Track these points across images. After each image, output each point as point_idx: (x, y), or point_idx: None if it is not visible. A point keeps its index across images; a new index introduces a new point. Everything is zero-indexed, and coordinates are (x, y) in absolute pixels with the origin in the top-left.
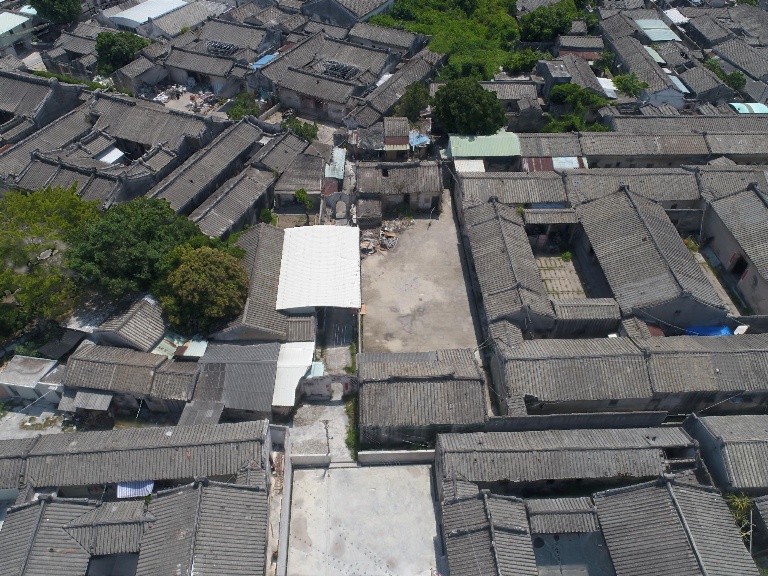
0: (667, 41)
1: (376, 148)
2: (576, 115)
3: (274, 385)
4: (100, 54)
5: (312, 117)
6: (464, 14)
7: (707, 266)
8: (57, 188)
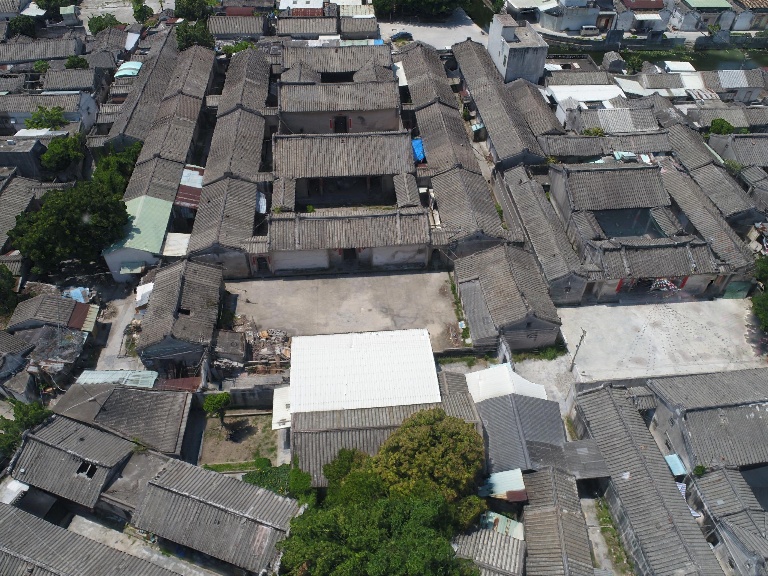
0: None
1: (82, 342)
2: None
3: None
4: None
5: None
6: None
7: None
8: None
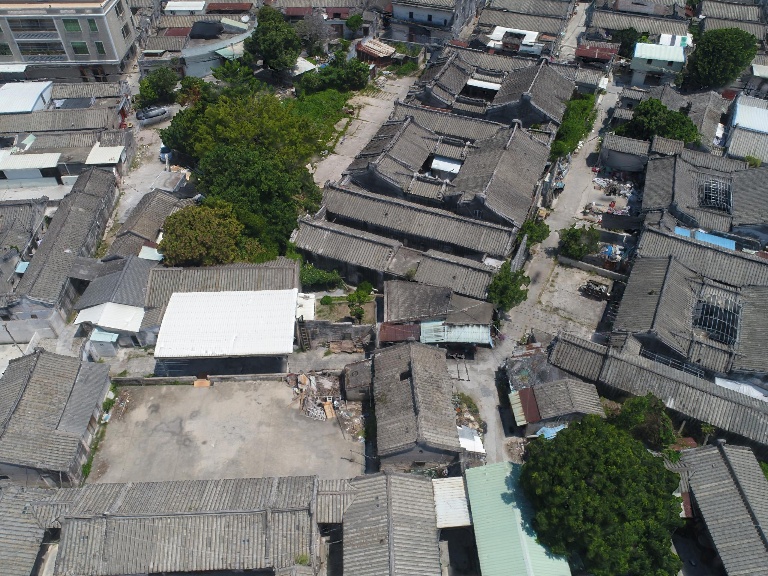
0: None
1: (512, 381)
2: None
3: (93, 306)
4: (633, 115)
5: None
6: None
7: None
8: (289, 120)
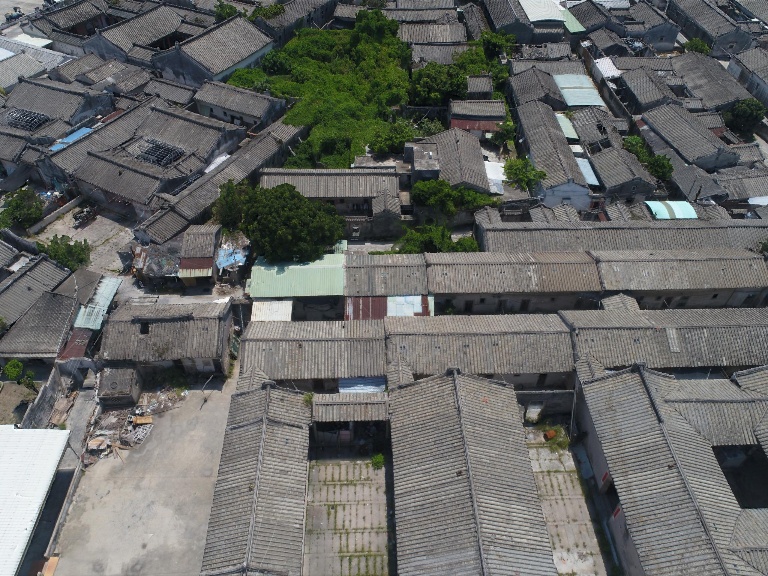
0: (585, 107)
1: (167, 274)
2: (447, 218)
3: None
4: None
5: (117, 215)
6: (352, 65)
7: (576, 477)
8: None
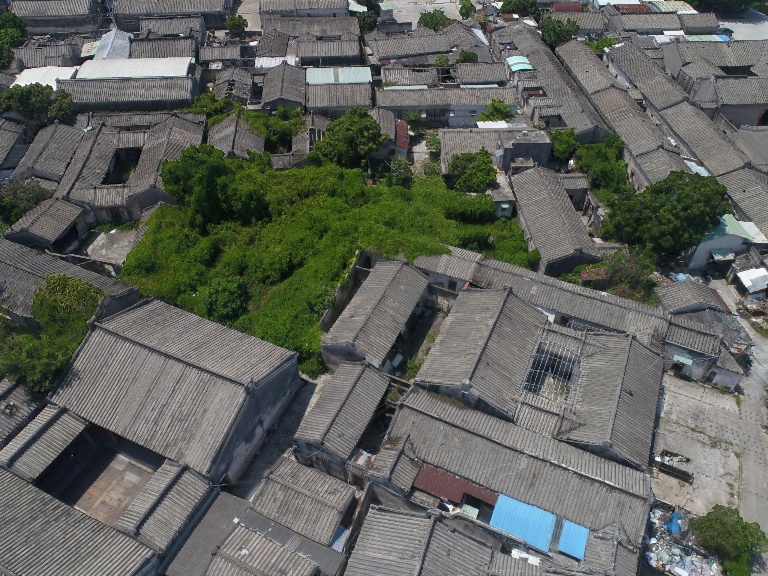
0: None
1: (741, 325)
2: None
3: None
4: None
5: None
6: (236, 223)
7: None
8: None
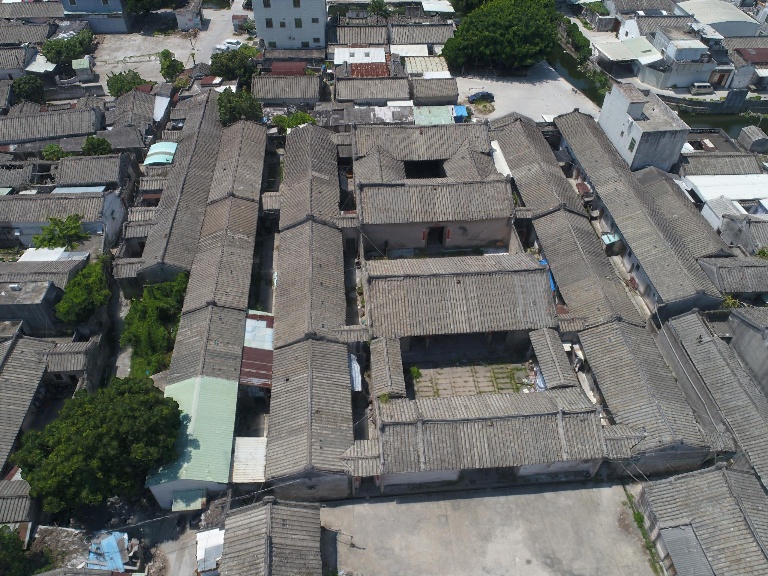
0: None
1: None
2: None
3: None
4: None
5: None
6: None
7: None
8: None
